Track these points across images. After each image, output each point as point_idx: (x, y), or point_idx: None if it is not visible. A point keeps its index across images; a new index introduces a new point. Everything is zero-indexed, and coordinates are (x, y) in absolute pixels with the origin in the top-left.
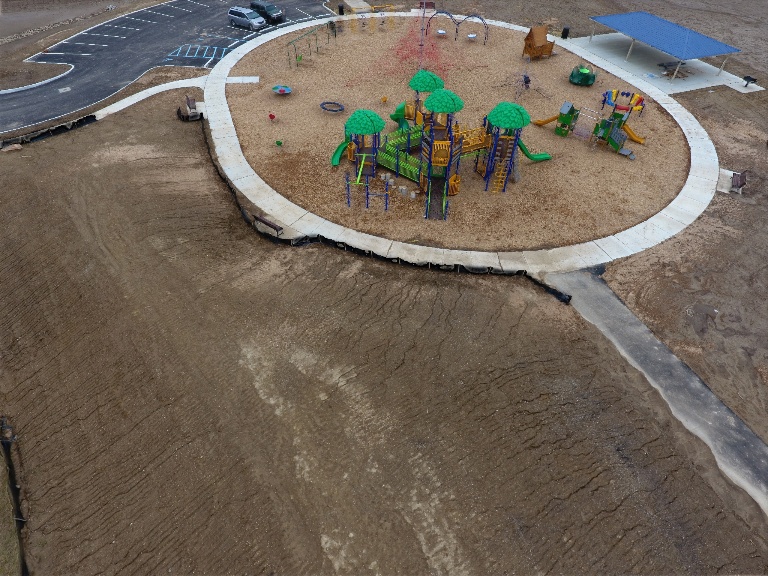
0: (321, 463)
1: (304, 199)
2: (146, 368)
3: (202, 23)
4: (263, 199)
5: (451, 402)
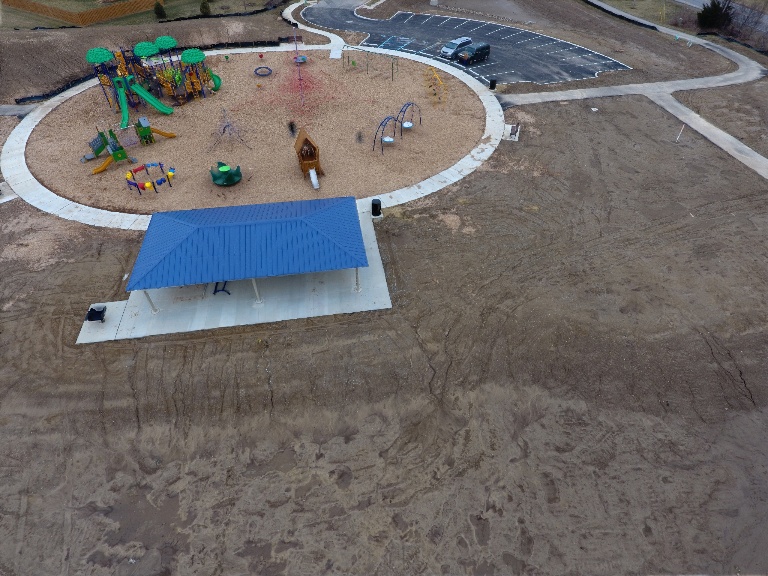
0: (7, 33)
1: None
2: None
3: None
4: None
5: (1, 55)
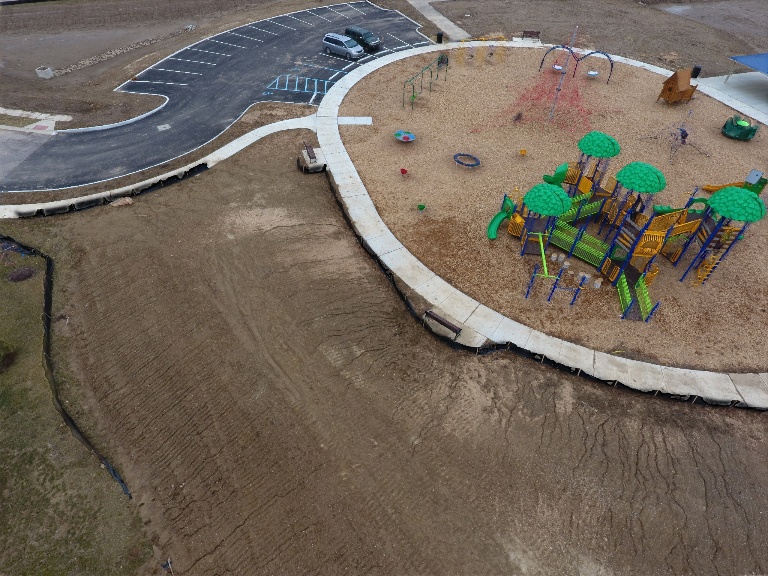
0: None
1: (469, 285)
2: (384, 575)
3: (293, 49)
4: (422, 283)
5: None
